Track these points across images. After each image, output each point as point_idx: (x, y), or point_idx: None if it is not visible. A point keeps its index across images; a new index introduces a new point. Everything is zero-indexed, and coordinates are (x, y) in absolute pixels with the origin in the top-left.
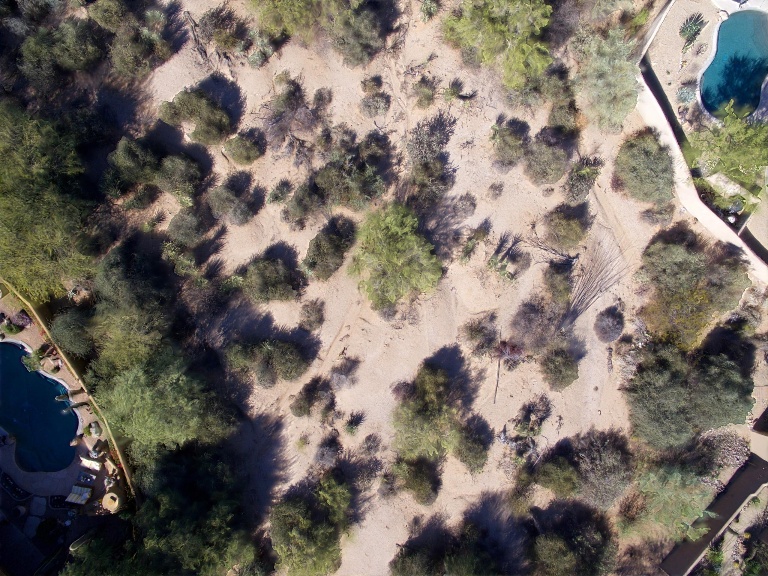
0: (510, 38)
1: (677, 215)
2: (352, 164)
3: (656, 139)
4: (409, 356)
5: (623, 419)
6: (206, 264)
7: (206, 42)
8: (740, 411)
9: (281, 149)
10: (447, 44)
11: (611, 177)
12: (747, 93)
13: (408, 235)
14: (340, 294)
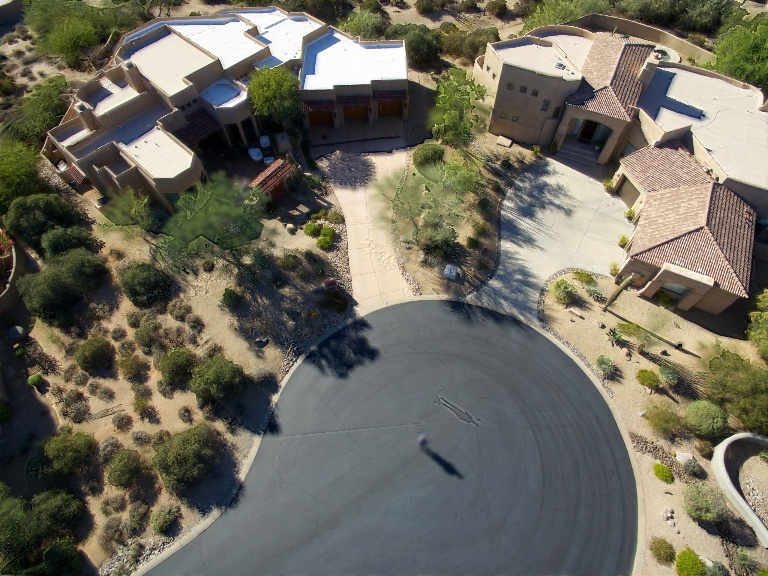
0: None
1: None
2: None
3: None
4: None
5: None
6: None
7: None
8: None
9: None
10: None
11: None
12: None
13: None
14: None
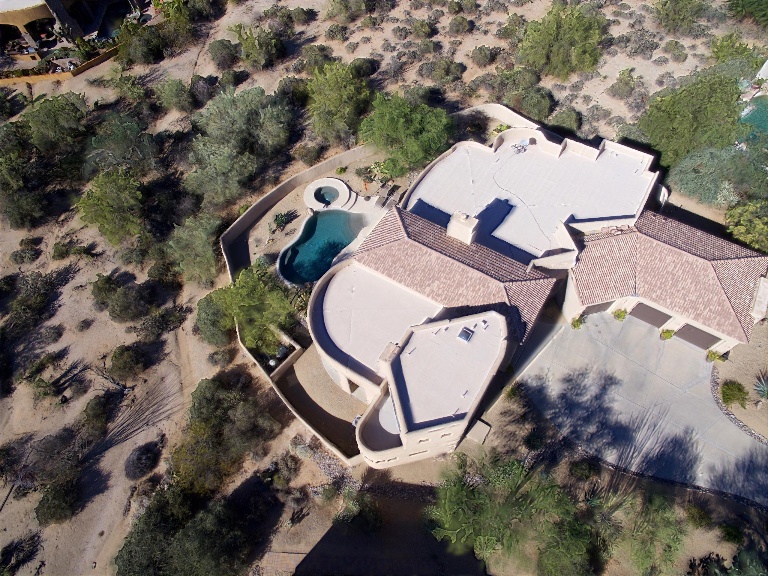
0: None
1: (239, 358)
2: None
3: None
4: None
5: None
6: None
7: None
8: (199, 567)
9: None
10: None
11: (195, 322)
12: None
13: None
14: None
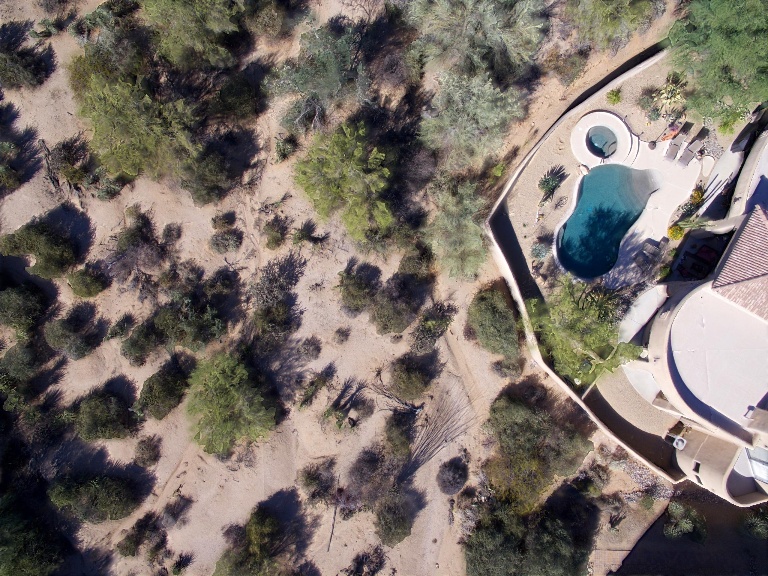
0: (347, 196)
1: (528, 368)
2: (188, 308)
3: (509, 291)
4: (243, 499)
5: (461, 574)
6: (45, 394)
7: (58, 172)
8: None
9: (127, 282)
10: (301, 184)
11: (464, 325)
12: (609, 246)
13: (235, 387)
14: (179, 430)
